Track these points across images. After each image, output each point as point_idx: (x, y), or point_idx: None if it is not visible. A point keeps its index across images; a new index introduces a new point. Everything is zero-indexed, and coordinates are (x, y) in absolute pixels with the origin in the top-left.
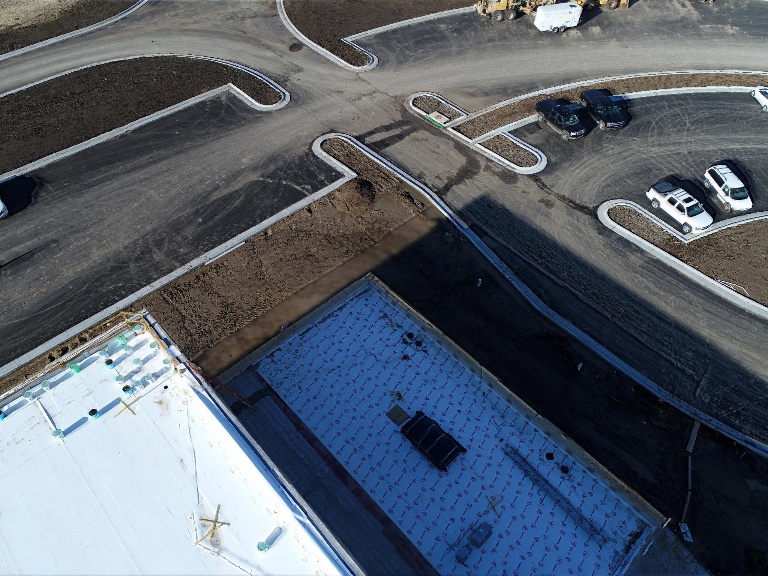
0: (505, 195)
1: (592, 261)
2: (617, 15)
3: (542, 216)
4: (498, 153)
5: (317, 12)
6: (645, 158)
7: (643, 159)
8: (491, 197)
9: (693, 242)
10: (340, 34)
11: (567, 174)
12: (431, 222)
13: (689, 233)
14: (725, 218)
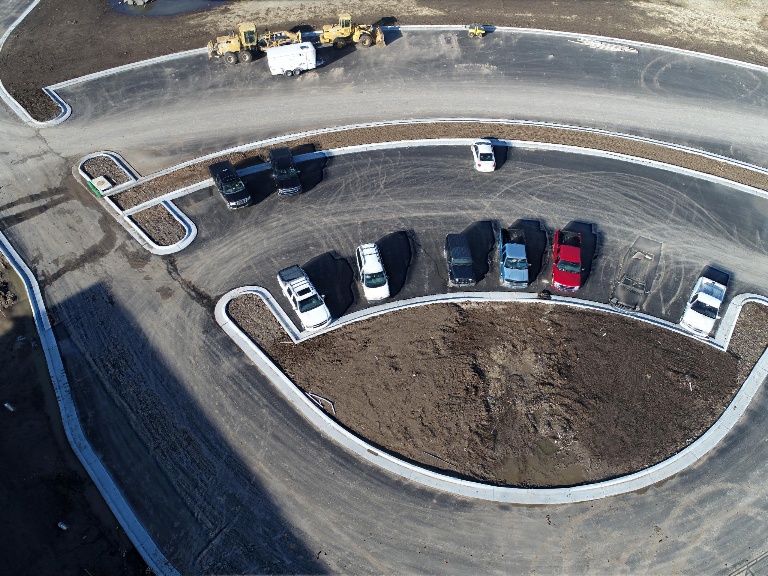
0: (121, 283)
1: (174, 370)
2: (370, 54)
3: (149, 310)
4: (143, 228)
5: (34, 56)
6: (309, 231)
7: (306, 232)
8: (103, 286)
9: (305, 342)
10: (44, 82)
11: (209, 253)
12: (7, 323)
13: (305, 330)
14: (359, 309)
